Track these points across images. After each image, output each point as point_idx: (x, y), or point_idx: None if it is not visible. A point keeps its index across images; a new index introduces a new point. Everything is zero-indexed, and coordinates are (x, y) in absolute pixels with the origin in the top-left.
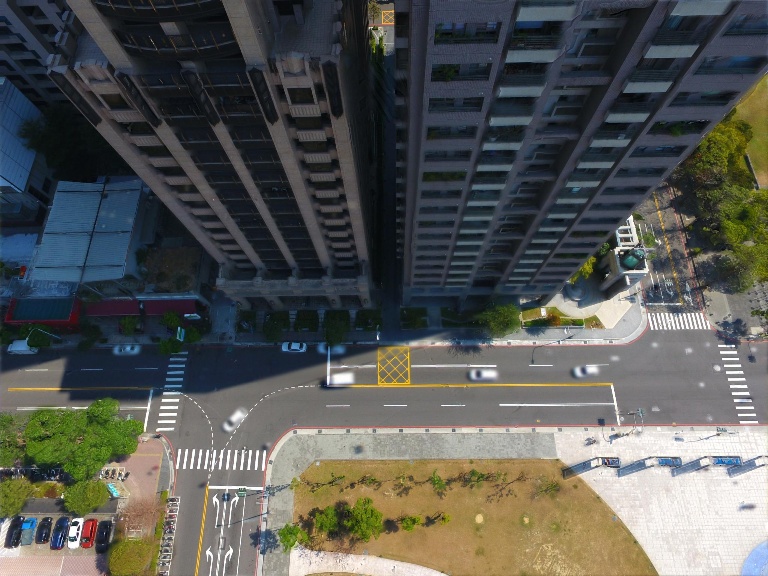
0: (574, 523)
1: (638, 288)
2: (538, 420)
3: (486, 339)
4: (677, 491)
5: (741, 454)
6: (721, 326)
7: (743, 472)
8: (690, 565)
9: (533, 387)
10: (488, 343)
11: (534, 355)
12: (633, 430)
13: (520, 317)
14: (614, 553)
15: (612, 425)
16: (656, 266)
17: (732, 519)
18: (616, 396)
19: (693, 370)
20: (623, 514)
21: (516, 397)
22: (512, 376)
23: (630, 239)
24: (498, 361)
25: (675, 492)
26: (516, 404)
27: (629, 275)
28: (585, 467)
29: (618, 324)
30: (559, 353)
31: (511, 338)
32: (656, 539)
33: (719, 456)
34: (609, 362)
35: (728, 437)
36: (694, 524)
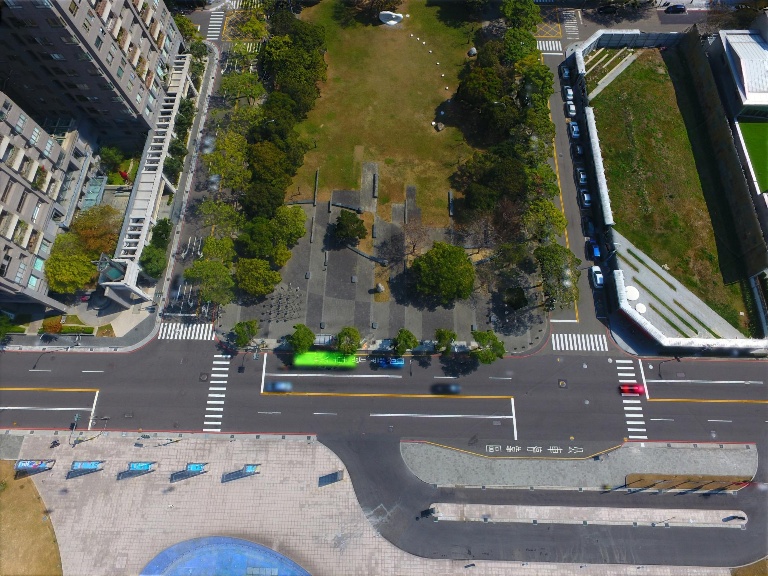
0: (4, 521)
1: (163, 299)
2: (15, 423)
3: (0, 344)
4: (115, 494)
5: (191, 460)
6: (225, 337)
7: (185, 478)
8: (96, 565)
9: (24, 391)
10: (1, 348)
11: (38, 361)
12: (100, 435)
13: (40, 324)
14: (30, 551)
15: (82, 429)
16: (188, 278)
17: (154, 522)
18: (97, 402)
19: (180, 379)
20: (55, 514)
21: (4, 400)
22: (9, 380)
23: (135, 252)
24: (2, 365)
25: (113, 495)
26: (1, 407)
27: (112, 286)
28: (39, 469)
29: (129, 333)
30: (62, 359)
31: (24, 344)
32: (75, 539)
33: (145, 461)
34: (105, 369)
35: (186, 444)
36: (117, 526)
